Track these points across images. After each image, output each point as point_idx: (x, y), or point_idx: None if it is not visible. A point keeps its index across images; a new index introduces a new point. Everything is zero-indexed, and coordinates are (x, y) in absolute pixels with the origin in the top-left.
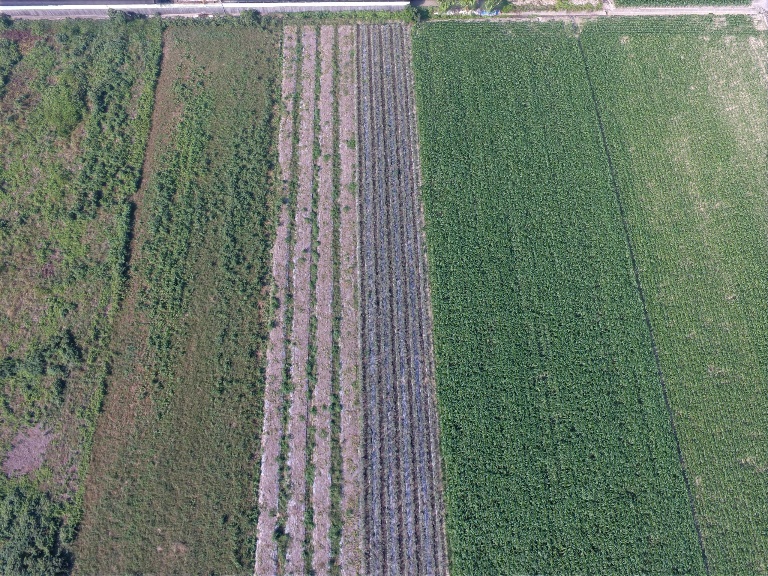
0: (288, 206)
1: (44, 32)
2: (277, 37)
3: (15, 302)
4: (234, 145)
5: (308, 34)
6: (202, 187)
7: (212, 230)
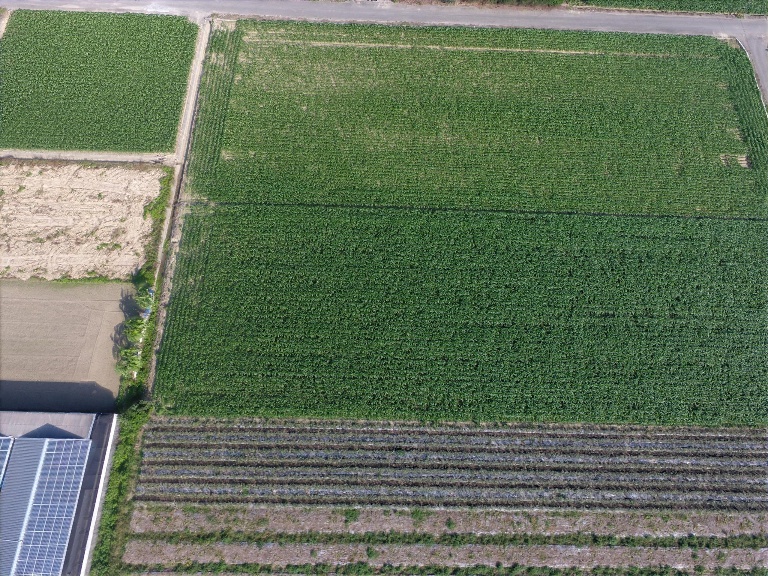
0: None
1: None
2: None
3: None
4: None
5: None
6: None
7: None
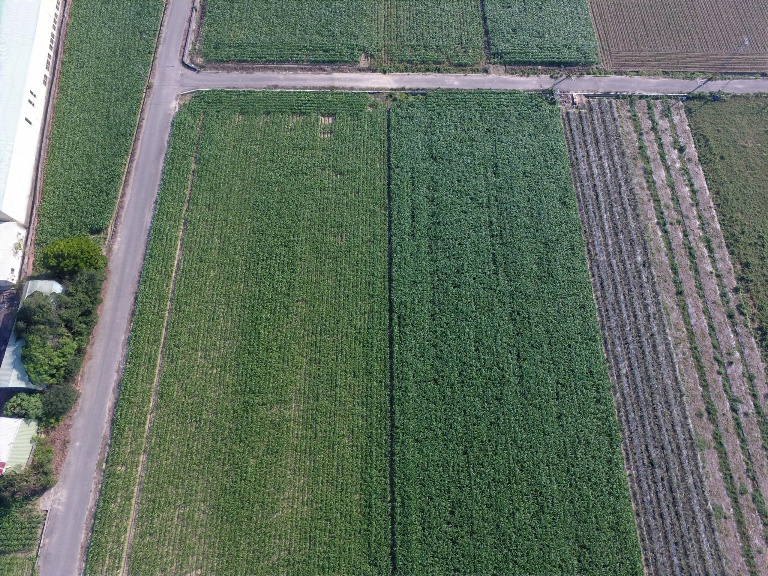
0: (767, 419)
1: None
2: None
3: None
4: None
5: None
6: None
7: None
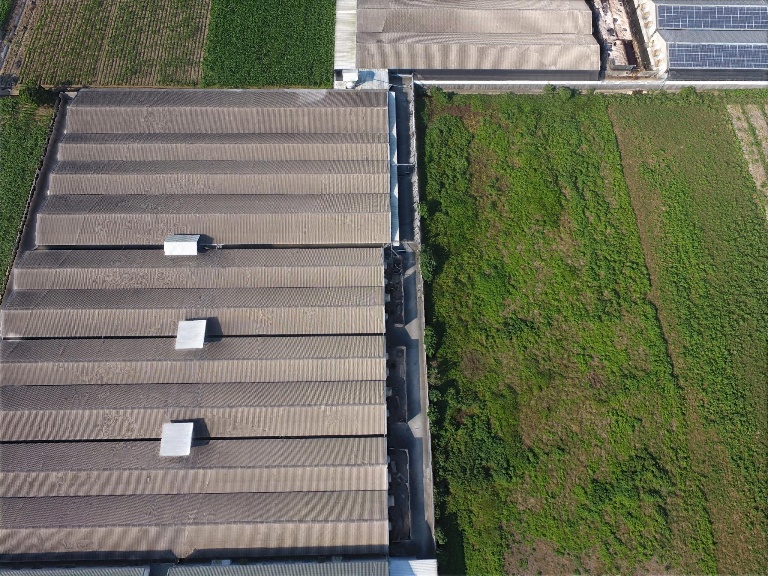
0: None
1: (485, 108)
2: (725, 117)
3: (576, 415)
4: (733, 239)
5: (754, 114)
6: (717, 286)
7: (748, 336)
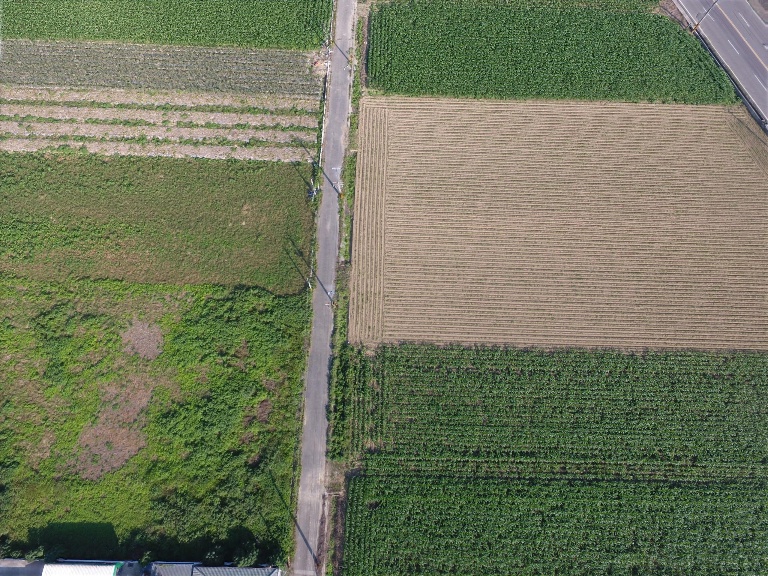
0: None
1: None
2: None
3: None
4: None
5: None
6: None
7: None
